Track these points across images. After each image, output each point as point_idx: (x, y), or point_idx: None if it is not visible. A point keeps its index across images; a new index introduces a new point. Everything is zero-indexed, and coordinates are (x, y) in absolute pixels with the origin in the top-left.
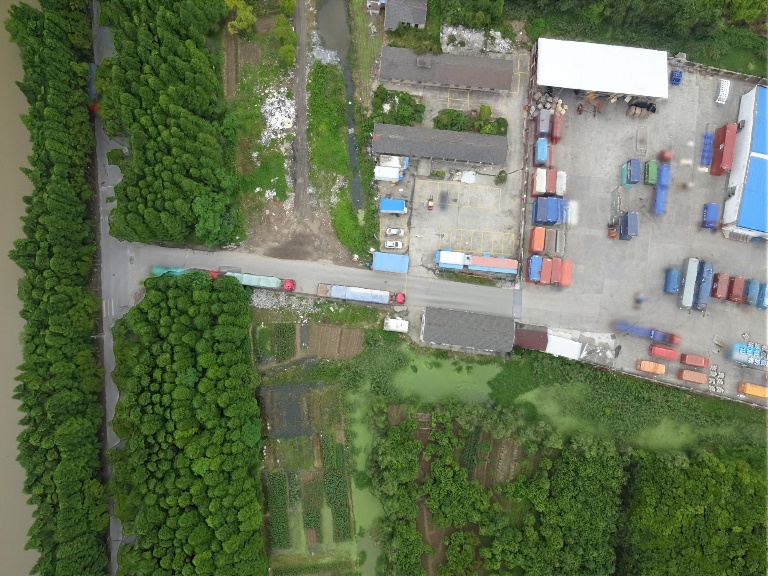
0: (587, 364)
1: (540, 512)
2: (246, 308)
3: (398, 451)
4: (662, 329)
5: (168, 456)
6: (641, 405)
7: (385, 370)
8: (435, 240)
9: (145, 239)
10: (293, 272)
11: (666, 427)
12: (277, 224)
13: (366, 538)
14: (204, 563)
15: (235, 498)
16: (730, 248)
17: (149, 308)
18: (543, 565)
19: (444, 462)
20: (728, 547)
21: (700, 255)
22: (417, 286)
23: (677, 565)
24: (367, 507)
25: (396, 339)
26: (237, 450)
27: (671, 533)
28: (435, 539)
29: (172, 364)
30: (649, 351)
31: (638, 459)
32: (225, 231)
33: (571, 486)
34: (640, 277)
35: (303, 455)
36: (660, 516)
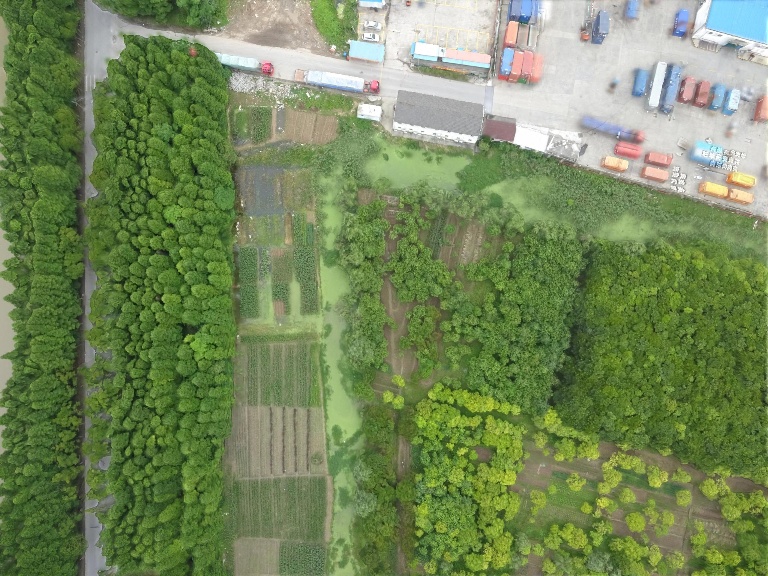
0: (553, 158)
1: (500, 291)
2: (224, 84)
3: (366, 225)
4: (628, 130)
5: (141, 199)
6: (603, 199)
7: (357, 154)
8: (411, 35)
9: (127, 9)
10: (272, 58)
11: (627, 223)
12: (258, 12)
13: (332, 312)
14: (173, 303)
15: (205, 250)
16: (699, 57)
17: (128, 60)
18: (500, 338)
19: (410, 238)
20: (678, 327)
21: (669, 62)
22: (392, 78)
23: (628, 340)
24: (334, 284)
25: (369, 127)
26: (209, 207)
27: (624, 310)
28: (398, 316)
29: (148, 115)
30: (614, 150)
31: (597, 245)
32: (206, 8)
33: (531, 265)
34: (610, 80)
35: (275, 232)
36: (615, 295)
